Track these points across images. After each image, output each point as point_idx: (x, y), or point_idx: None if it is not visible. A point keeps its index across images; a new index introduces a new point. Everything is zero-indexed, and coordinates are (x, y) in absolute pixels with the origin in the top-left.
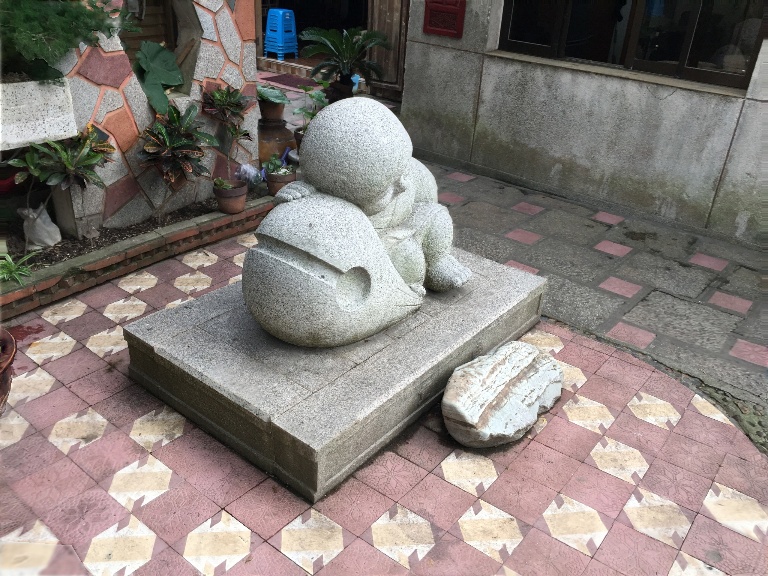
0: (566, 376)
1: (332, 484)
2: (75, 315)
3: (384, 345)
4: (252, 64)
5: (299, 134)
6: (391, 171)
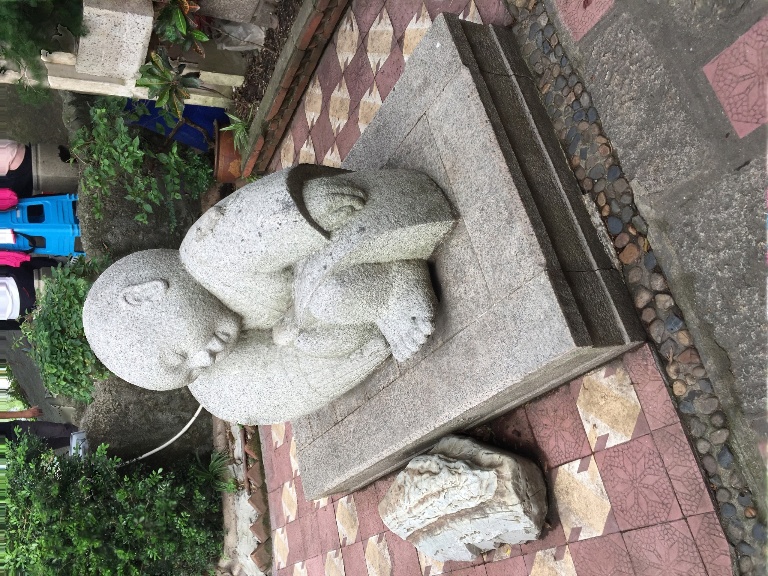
0: (580, 506)
1: (358, 488)
2: (290, 163)
3: (357, 405)
4: None
5: None
6: None
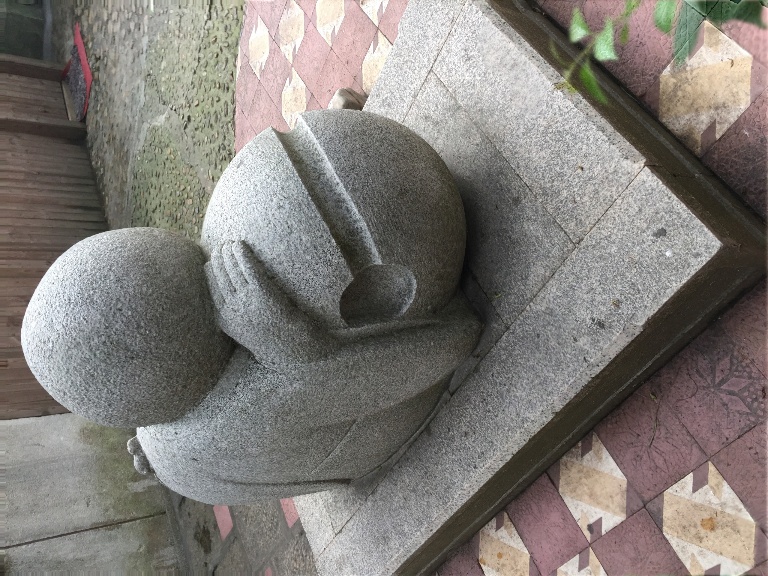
0: None
1: None
2: None
3: None
4: None
5: None
6: None
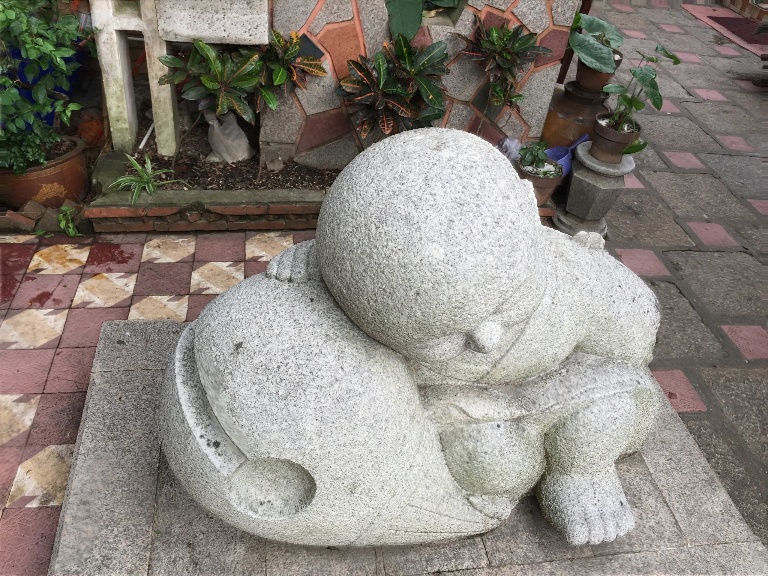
0: None
1: None
2: (170, 259)
3: (348, 575)
4: (573, 1)
5: (598, 123)
6: (432, 317)
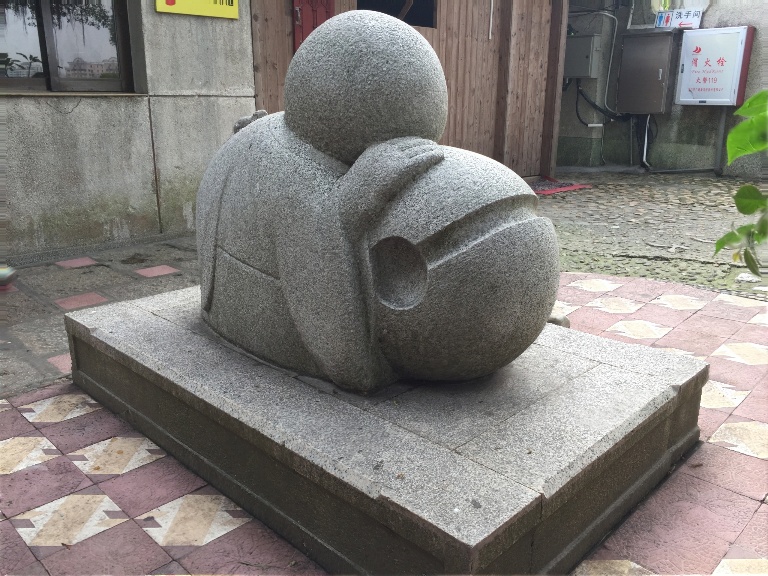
0: None
1: None
2: None
3: None
4: None
5: None
6: None
